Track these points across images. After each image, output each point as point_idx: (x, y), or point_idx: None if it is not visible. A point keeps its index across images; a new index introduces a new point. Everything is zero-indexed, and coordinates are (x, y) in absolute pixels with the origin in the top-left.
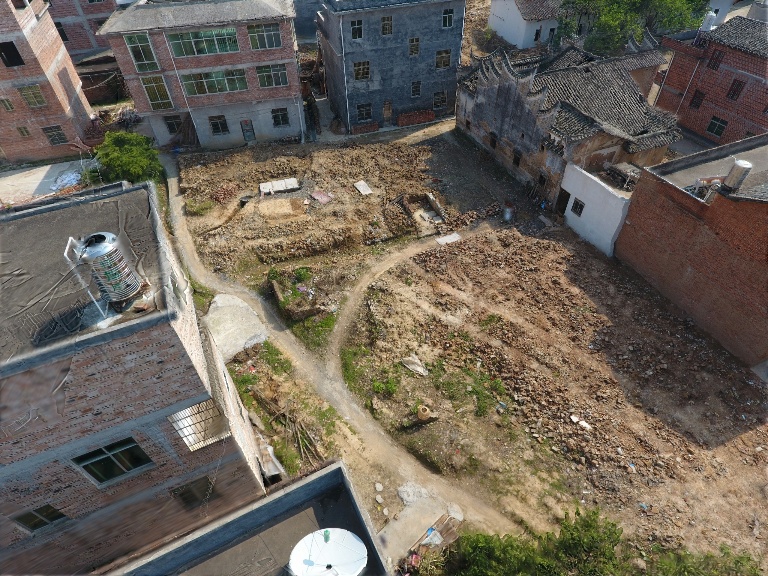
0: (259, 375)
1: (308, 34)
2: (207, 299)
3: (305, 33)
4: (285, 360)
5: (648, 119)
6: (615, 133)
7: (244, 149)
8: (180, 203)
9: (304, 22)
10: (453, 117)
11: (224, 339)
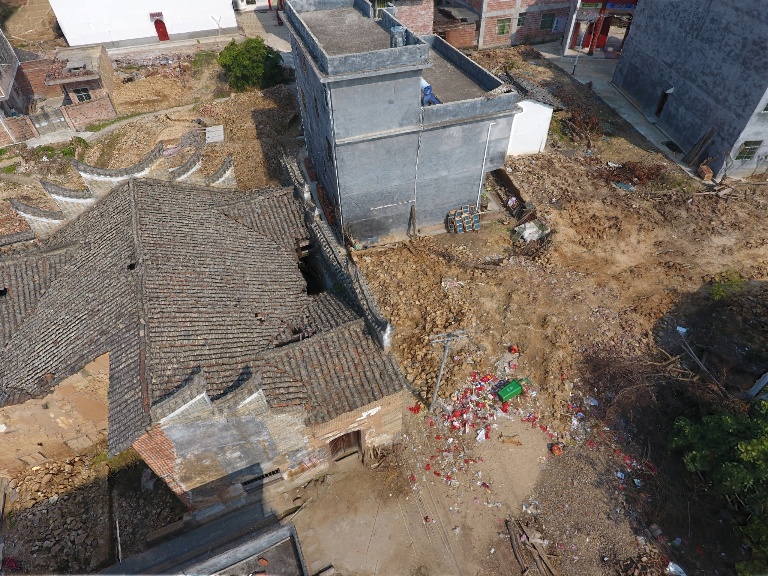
0: (3, 156)
1: (643, 104)
2: None
3: (642, 100)
4: (0, 160)
5: (2, 390)
6: None
7: (286, 109)
8: (218, 101)
9: (648, 85)
10: (338, 244)
11: (44, 139)
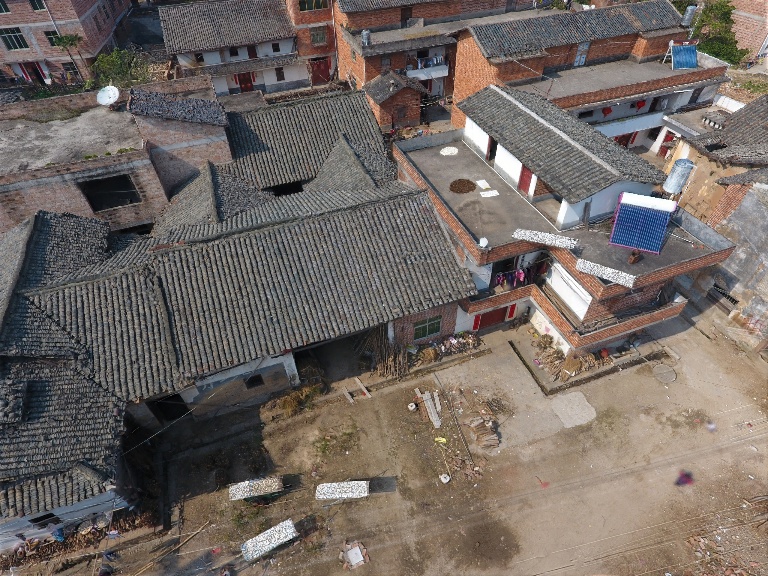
0: None
1: None
2: None
3: None
4: None
5: None
6: (761, 100)
7: None
8: None
9: None
10: None
11: None
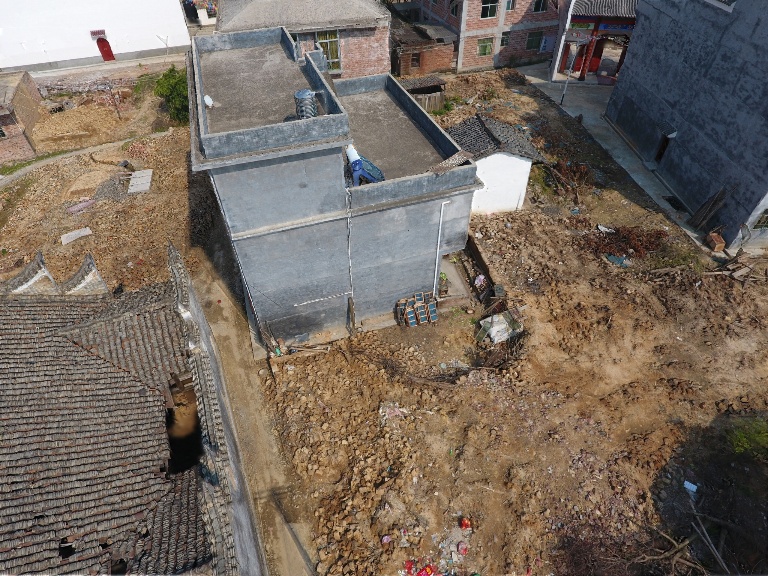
0: None
1: (641, 145)
2: (7, 173)
3: (639, 141)
4: None
5: None
6: None
7: None
8: (155, 136)
9: (646, 124)
10: (258, 342)
11: None
